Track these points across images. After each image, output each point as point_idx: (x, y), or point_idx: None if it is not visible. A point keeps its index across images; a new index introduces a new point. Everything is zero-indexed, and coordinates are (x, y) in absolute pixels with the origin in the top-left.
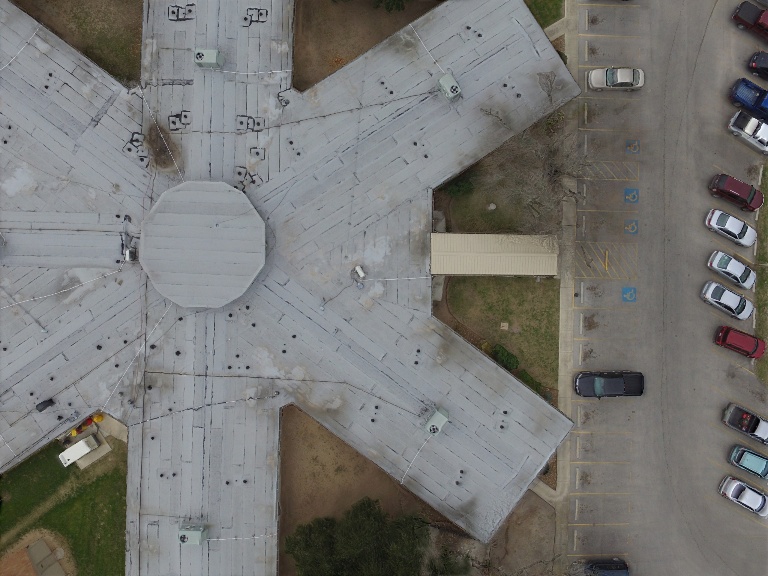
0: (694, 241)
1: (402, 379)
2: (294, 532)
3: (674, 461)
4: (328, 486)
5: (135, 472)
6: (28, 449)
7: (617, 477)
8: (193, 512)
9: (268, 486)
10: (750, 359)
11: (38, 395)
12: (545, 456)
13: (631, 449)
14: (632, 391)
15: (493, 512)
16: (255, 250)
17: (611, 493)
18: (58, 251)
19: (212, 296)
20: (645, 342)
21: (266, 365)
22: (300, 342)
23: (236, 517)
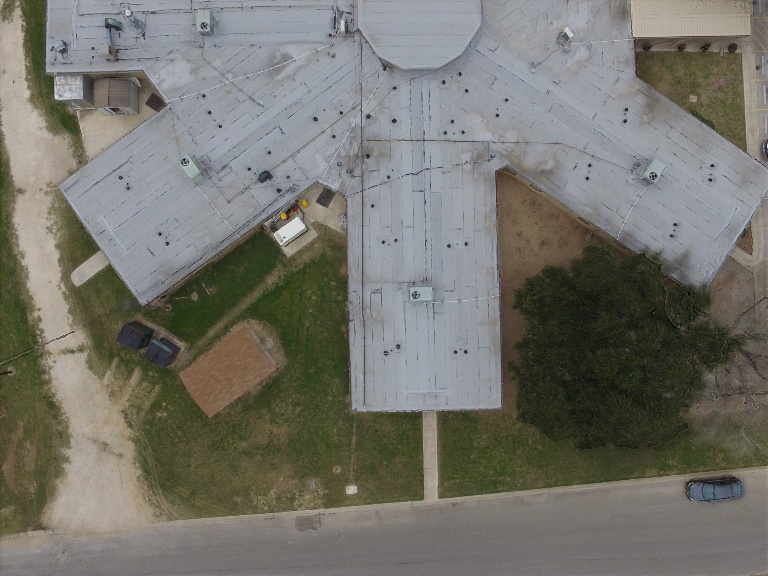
0: None
1: (614, 136)
2: (524, 282)
3: None
4: (534, 260)
5: (356, 241)
6: (249, 223)
7: None
8: (417, 276)
9: (488, 249)
10: None
11: (255, 170)
12: (752, 207)
13: None
14: None
15: (707, 263)
16: (471, 11)
17: None
18: (270, 28)
19: (432, 56)
20: None
21: (480, 130)
22: (512, 106)
23: (458, 280)
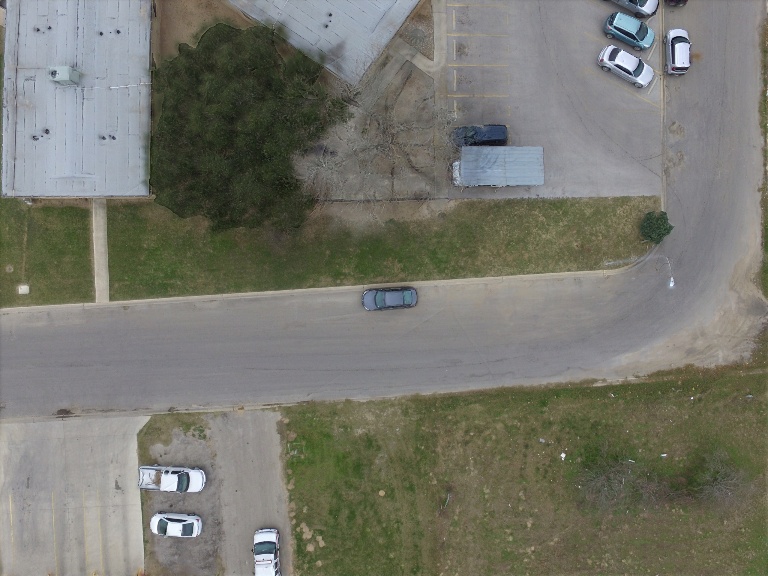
0: None
1: None
2: None
3: (552, 35)
4: None
5: (13, 30)
6: None
7: (495, 49)
8: (68, 62)
9: (142, 38)
10: None
11: None
12: None
13: (508, 22)
14: None
15: (363, 55)
16: None
17: (490, 65)
18: None
19: None
20: None
21: None
22: None
23: (110, 68)
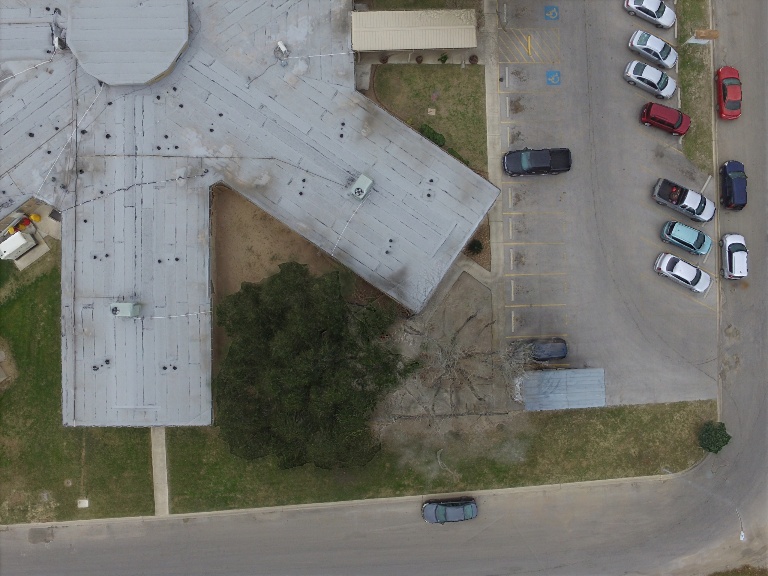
0: (615, 25)
1: (328, 151)
2: (224, 299)
3: (608, 241)
4: (264, 275)
5: (69, 256)
6: None
7: (552, 257)
8: (126, 291)
9: (200, 264)
10: (678, 138)
11: None
12: (473, 223)
13: (564, 229)
14: (560, 167)
15: (424, 281)
16: (178, 26)
17: (546, 274)
18: None
19: (138, 72)
20: (572, 124)
21: (195, 145)
22: (227, 121)
23: (169, 296)
